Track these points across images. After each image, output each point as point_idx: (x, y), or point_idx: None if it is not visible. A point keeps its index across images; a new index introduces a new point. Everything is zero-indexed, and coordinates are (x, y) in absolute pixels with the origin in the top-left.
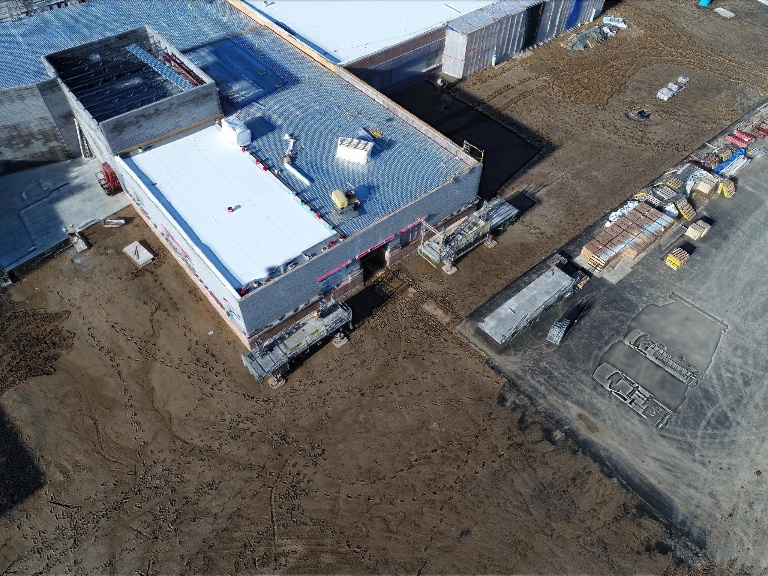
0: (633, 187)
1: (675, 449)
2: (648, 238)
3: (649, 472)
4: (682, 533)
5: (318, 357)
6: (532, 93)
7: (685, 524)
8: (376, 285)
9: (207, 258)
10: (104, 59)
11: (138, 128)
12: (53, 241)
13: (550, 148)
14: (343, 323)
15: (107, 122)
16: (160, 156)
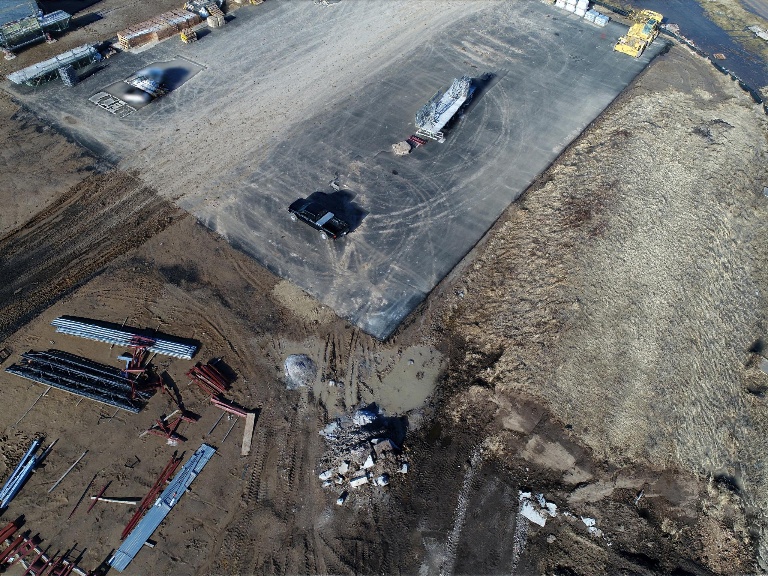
0: None
1: (126, 125)
2: (170, 25)
3: (100, 137)
4: (106, 160)
5: None
6: None
7: (110, 156)
8: None
9: None
10: None
11: None
12: None
13: None
14: None
15: None
16: None
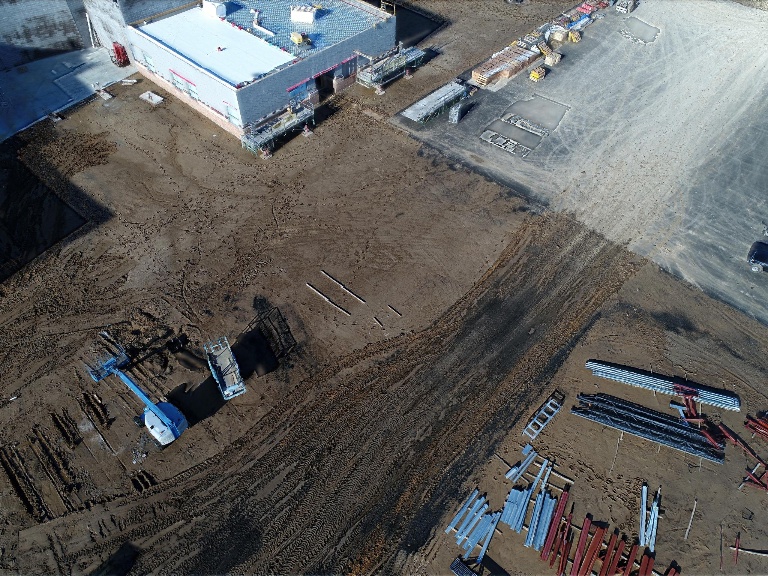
0: (509, 41)
1: (532, 166)
2: (517, 64)
3: (515, 177)
4: (535, 201)
5: (293, 142)
6: None
7: (537, 197)
8: (328, 104)
9: (209, 73)
10: None
11: (143, 5)
12: (85, 95)
13: (449, 23)
14: (308, 116)
15: None
16: (160, 26)
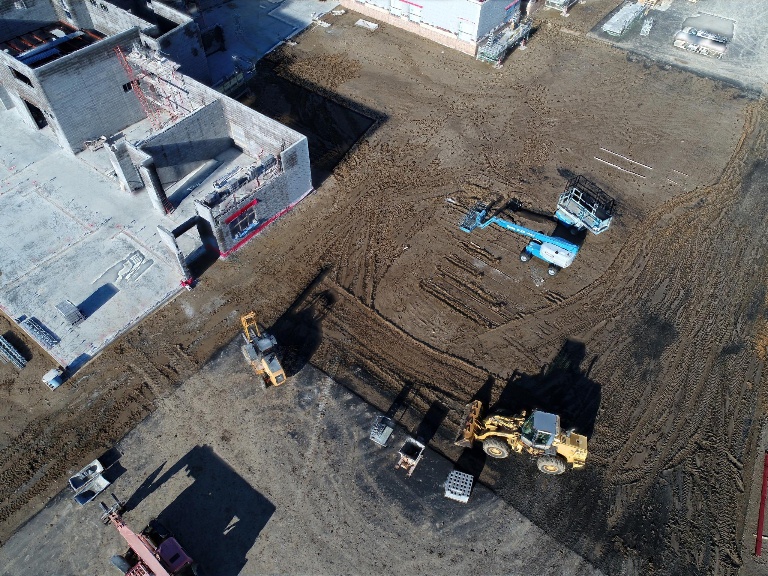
0: None
1: (731, 64)
2: None
3: (722, 73)
4: (749, 90)
5: (514, 55)
6: None
7: (749, 87)
8: None
9: None
10: None
11: None
12: (305, 24)
13: None
14: (527, 31)
15: None
16: None
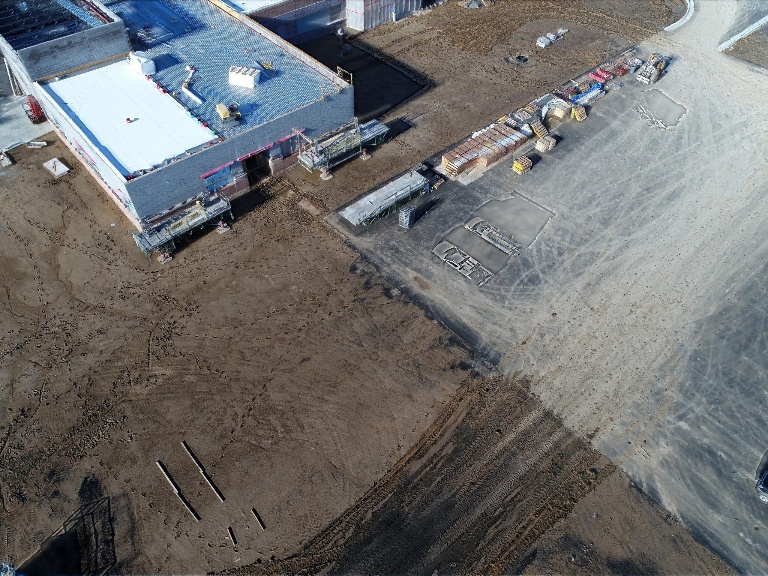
0: (499, 114)
1: (489, 299)
2: (499, 149)
3: (464, 315)
4: (482, 355)
5: (203, 241)
6: (425, 42)
7: (486, 349)
8: (261, 188)
9: (103, 154)
10: (28, 5)
11: (53, 58)
12: None
13: (432, 85)
14: (223, 211)
15: (24, 50)
16: (74, 83)
